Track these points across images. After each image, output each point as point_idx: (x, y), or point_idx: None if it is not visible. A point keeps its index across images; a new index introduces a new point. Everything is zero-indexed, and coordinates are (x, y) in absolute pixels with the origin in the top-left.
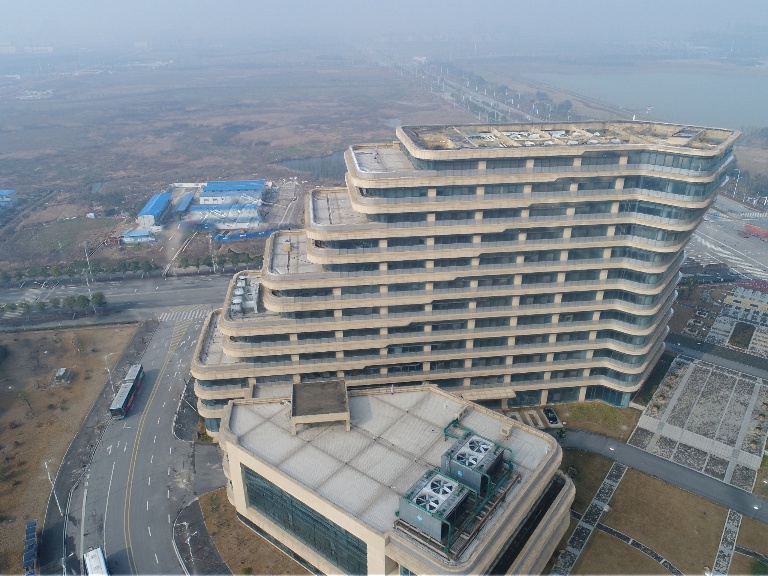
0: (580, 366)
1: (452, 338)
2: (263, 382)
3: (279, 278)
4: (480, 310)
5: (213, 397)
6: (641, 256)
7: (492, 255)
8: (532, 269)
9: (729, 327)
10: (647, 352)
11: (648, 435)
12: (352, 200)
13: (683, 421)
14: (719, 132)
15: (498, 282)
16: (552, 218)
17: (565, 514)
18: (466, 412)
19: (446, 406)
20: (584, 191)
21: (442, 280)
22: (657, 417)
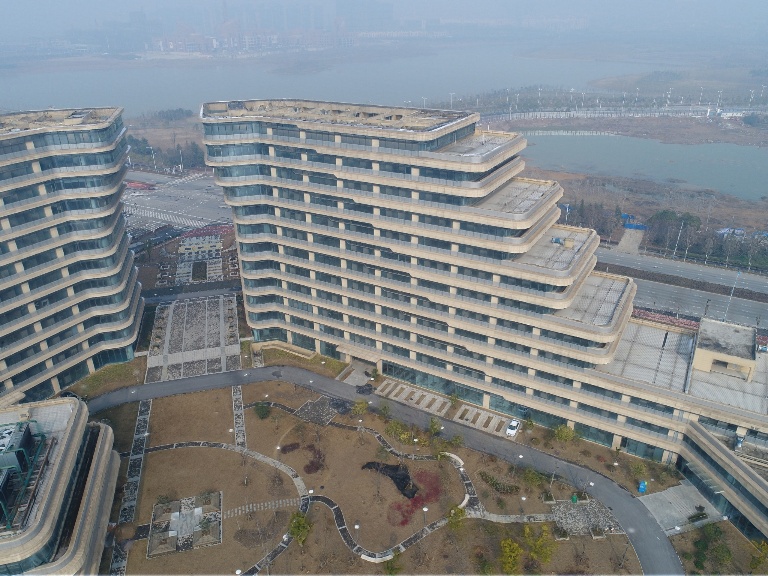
0: (76, 342)
1: None
2: None
3: None
4: None
5: None
6: (86, 226)
7: None
8: None
9: (188, 269)
10: (129, 306)
11: (158, 370)
12: None
13: (180, 347)
14: (106, 110)
15: None
16: None
17: (112, 453)
18: None
19: None
20: (4, 181)
21: None
22: (160, 353)
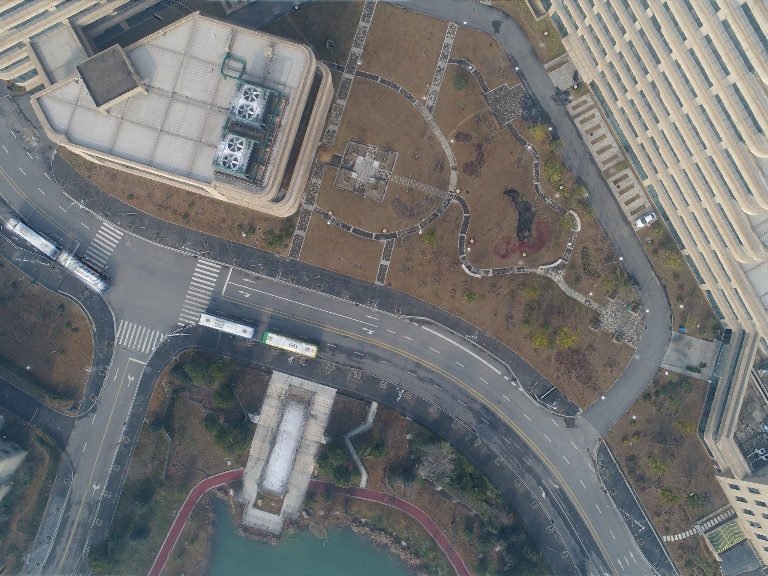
0: None
1: None
2: (36, 37)
3: None
4: None
5: (1, 67)
6: None
7: None
8: None
9: None
10: None
11: None
12: None
13: None
14: None
15: None
16: None
17: None
18: (233, 39)
19: (214, 35)
20: None
21: None
22: None
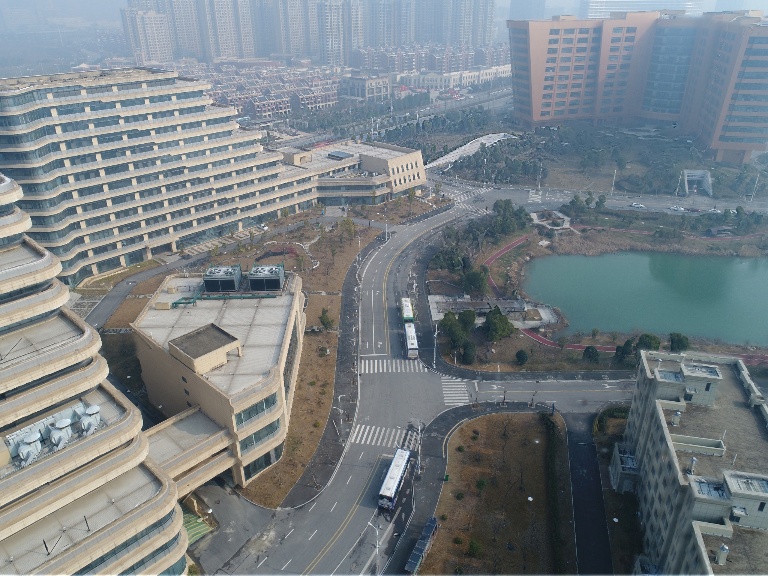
0: None
1: None
2: None
3: (91, 331)
4: None
5: None
6: None
7: None
8: None
9: None
10: None
11: None
12: (6, 227)
13: None
14: None
15: None
16: None
17: None
18: None
19: (154, 317)
20: None
21: None
22: None
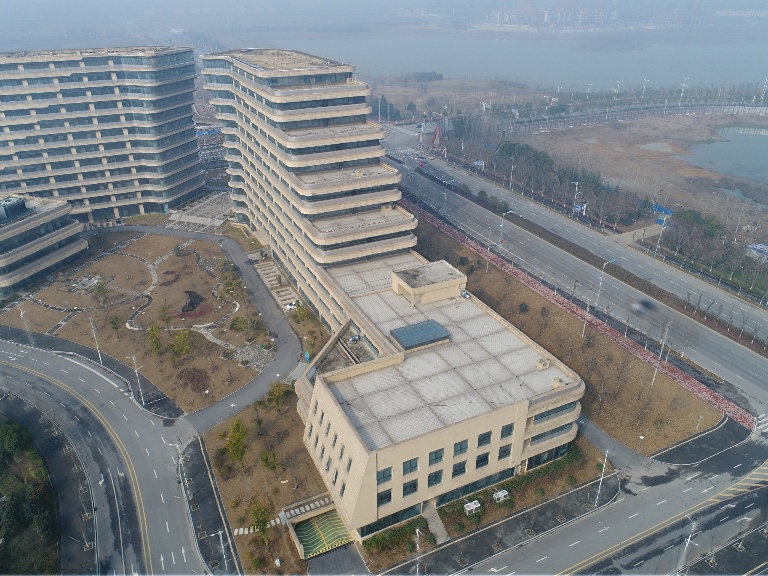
0: (131, 190)
1: (37, 176)
2: None
3: None
4: (51, 158)
5: None
6: (141, 118)
7: (47, 122)
8: (75, 129)
9: None
10: (171, 178)
11: (171, 222)
12: None
13: (194, 213)
14: None
15: (57, 139)
16: (78, 98)
17: None
18: (25, 200)
19: None
20: (93, 81)
21: (17, 139)
22: (180, 214)
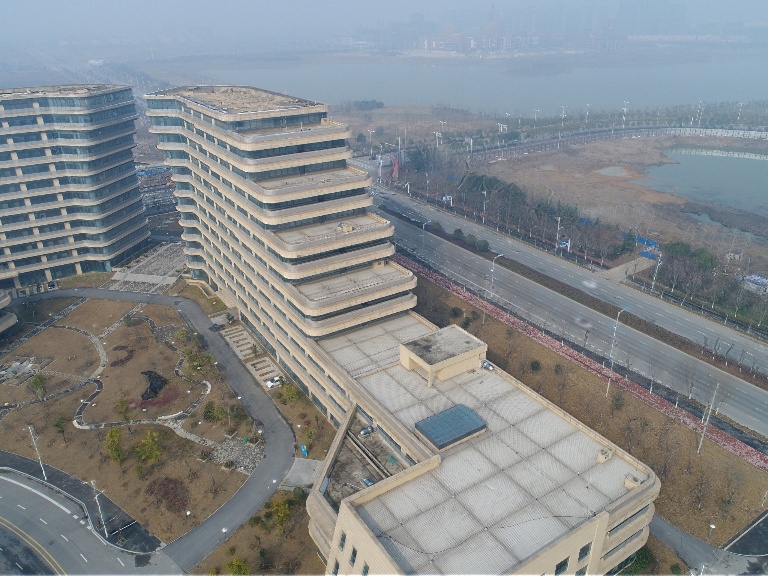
0: (66, 248)
1: None
2: None
3: None
4: None
5: None
6: (75, 167)
7: None
8: None
9: None
10: (112, 232)
11: (115, 282)
12: None
13: (141, 270)
14: None
15: None
16: None
17: None
18: None
19: None
20: (15, 127)
21: None
22: (125, 272)
